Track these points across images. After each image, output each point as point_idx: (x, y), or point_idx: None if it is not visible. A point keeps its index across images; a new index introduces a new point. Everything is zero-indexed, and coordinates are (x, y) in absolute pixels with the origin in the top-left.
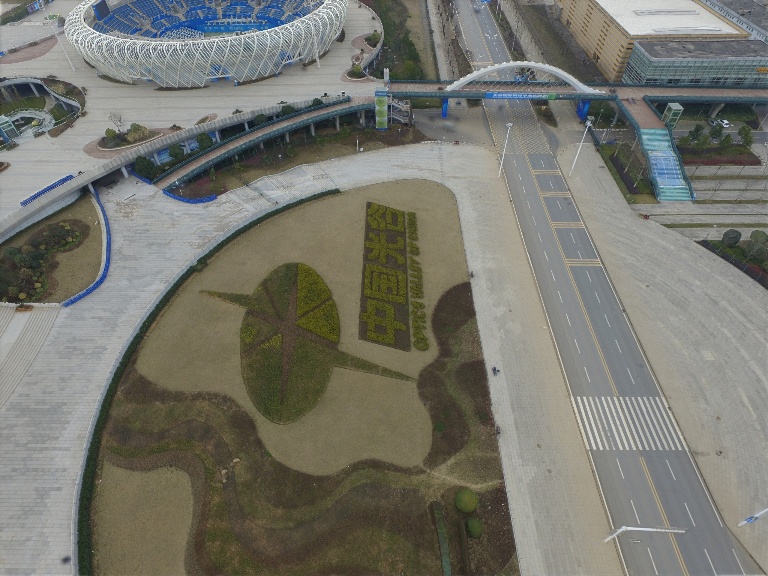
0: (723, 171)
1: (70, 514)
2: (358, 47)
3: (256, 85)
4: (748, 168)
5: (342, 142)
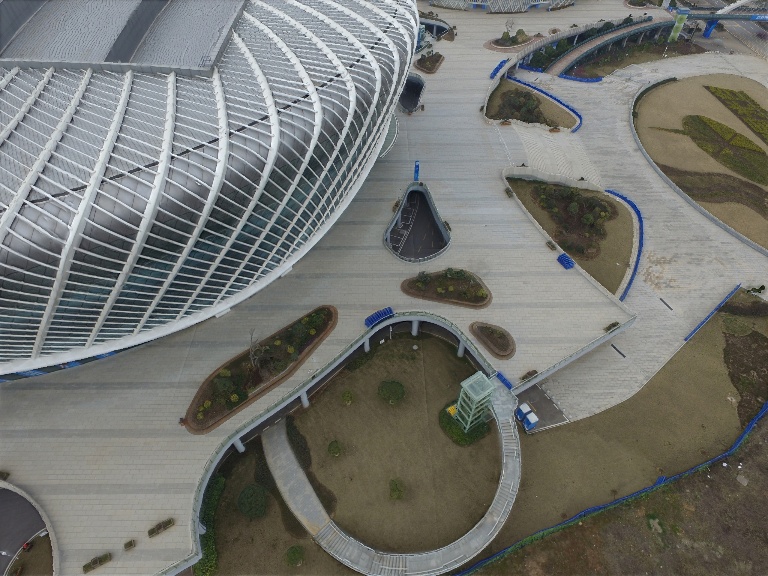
0: None
1: (702, 216)
2: None
3: (564, 11)
4: None
5: (648, 51)
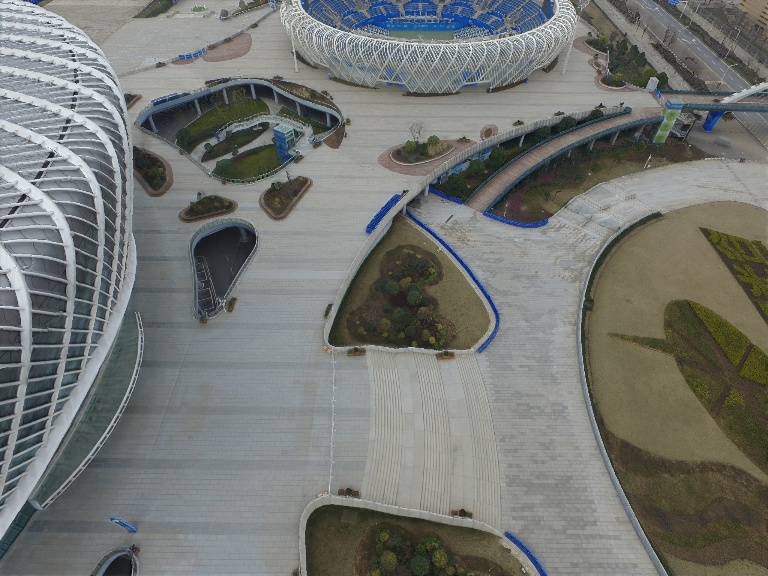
0: None
1: None
2: (585, 51)
3: (511, 92)
4: None
5: (624, 157)
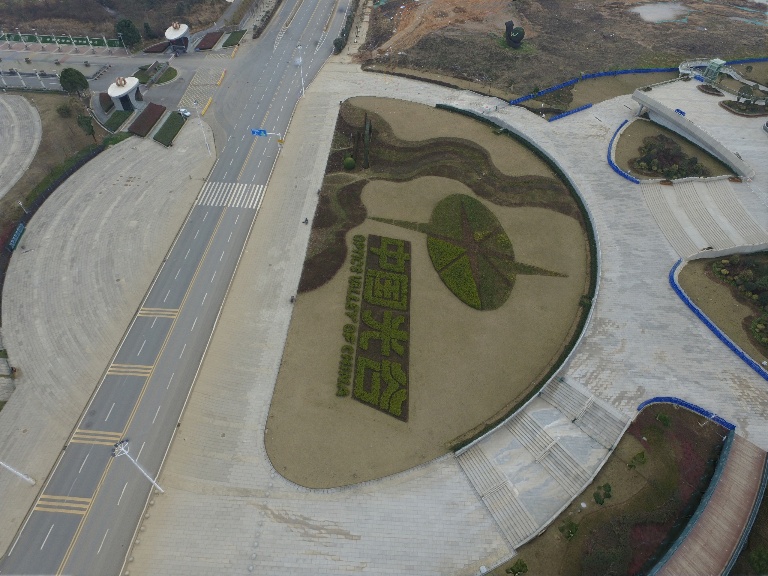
0: None
1: None
2: None
3: None
4: None
5: None
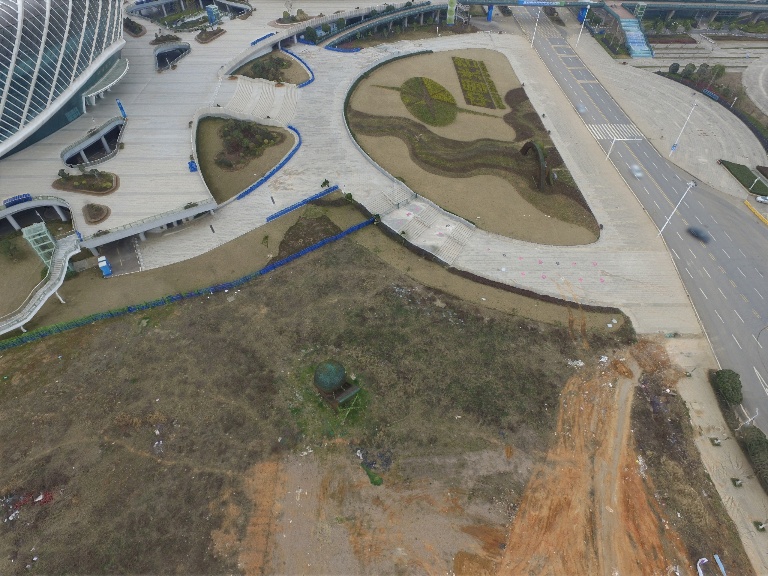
0: (672, 46)
1: (351, 144)
2: None
3: None
4: (688, 45)
5: (426, 31)
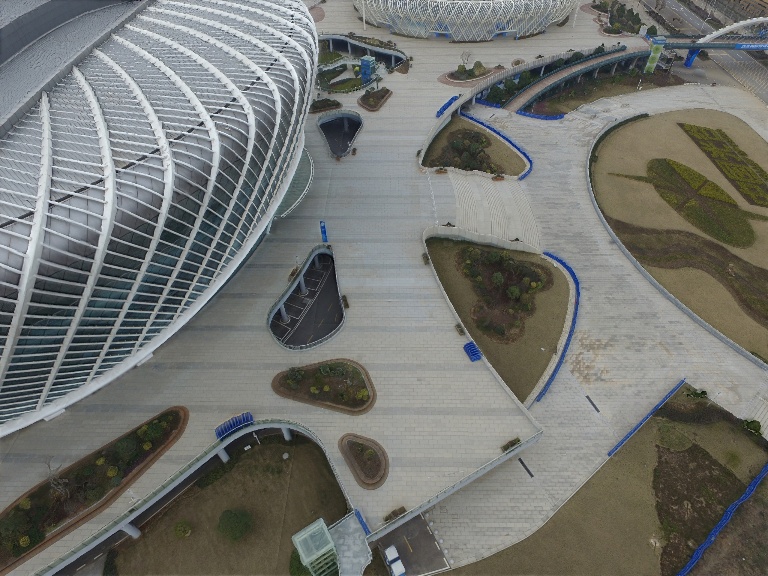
0: None
1: (651, 287)
2: (591, 13)
3: (533, 39)
4: None
5: (621, 83)
